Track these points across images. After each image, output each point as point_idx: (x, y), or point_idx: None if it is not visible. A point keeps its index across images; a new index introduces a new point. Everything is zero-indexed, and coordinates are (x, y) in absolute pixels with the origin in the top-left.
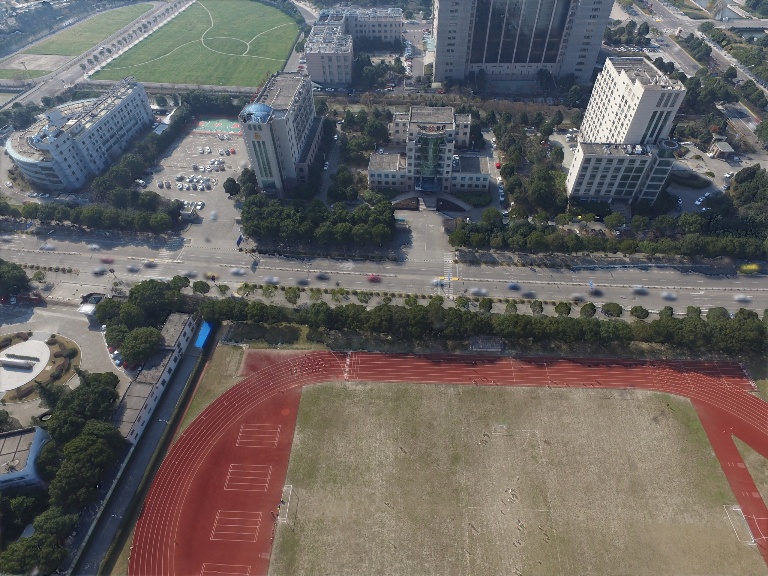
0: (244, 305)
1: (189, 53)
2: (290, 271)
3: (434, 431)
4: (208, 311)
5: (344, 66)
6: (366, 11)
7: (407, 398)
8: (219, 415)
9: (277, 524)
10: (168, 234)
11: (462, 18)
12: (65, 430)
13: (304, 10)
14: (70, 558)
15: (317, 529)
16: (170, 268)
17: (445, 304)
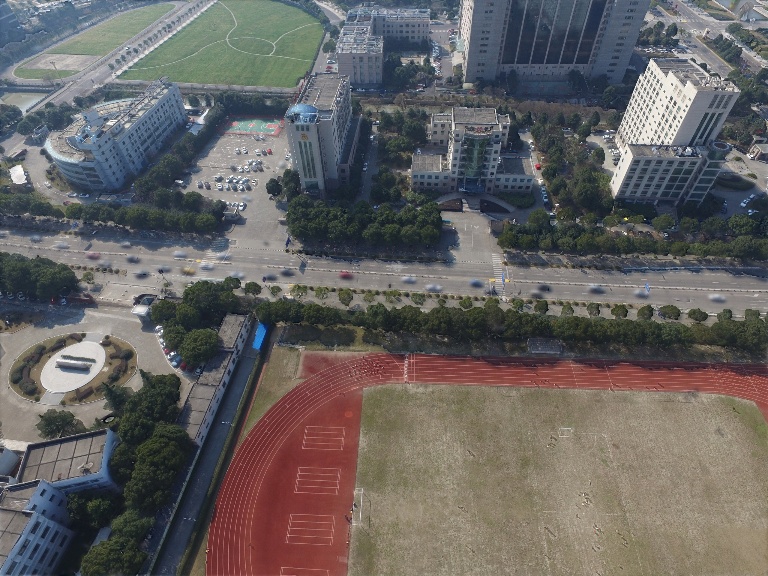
0: (300, 307)
1: (215, 53)
2: (339, 272)
3: (500, 434)
4: (264, 313)
5: (375, 66)
6: (389, 11)
7: (470, 401)
8: (282, 417)
9: (352, 528)
10: (212, 235)
11: (496, 19)
12: (137, 432)
13: (327, 10)
14: (148, 561)
15: (392, 533)
16: (218, 269)
17: (498, 306)
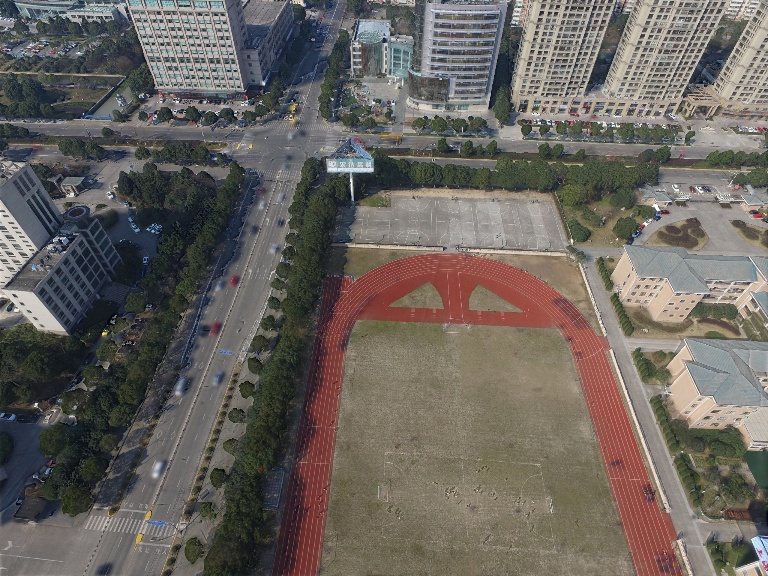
0: None
1: None
2: None
3: (385, 575)
4: None
5: None
6: None
7: None
8: None
9: None
10: None
11: None
12: None
13: None
14: None
15: None
16: None
17: None
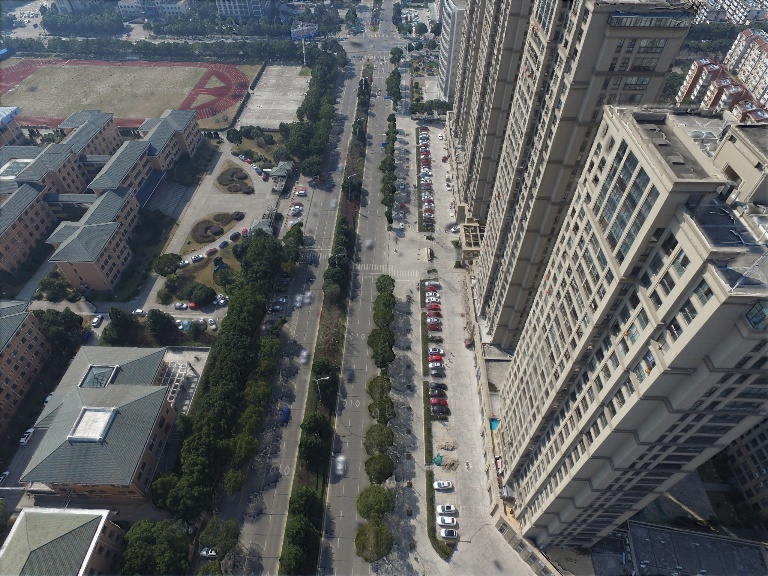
0: None
1: None
2: None
3: (90, 75)
4: (5, 41)
5: None
6: None
7: None
8: None
9: (8, 91)
10: (5, 31)
11: None
12: None
13: None
14: None
15: None
16: None
17: None
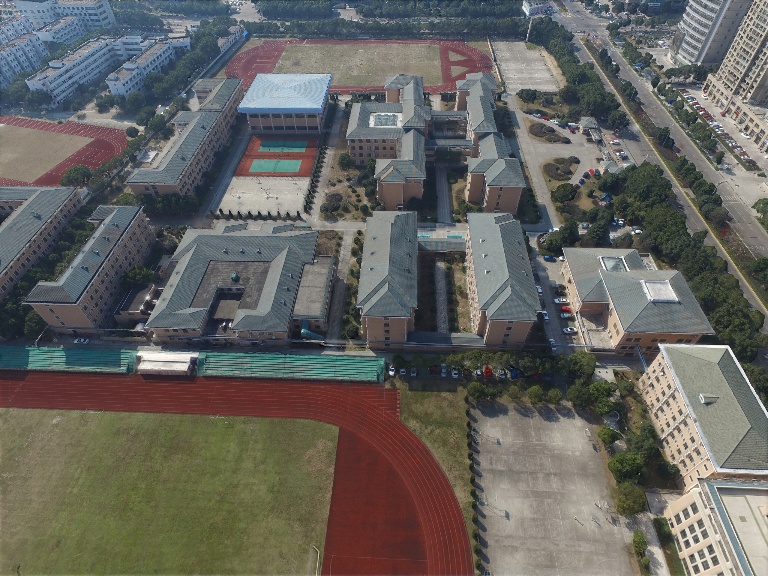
0: (262, 23)
1: None
2: None
3: None
4: (247, 24)
5: None
6: None
7: None
8: None
9: None
10: None
11: None
12: (200, 36)
13: None
14: None
15: None
16: None
17: None
